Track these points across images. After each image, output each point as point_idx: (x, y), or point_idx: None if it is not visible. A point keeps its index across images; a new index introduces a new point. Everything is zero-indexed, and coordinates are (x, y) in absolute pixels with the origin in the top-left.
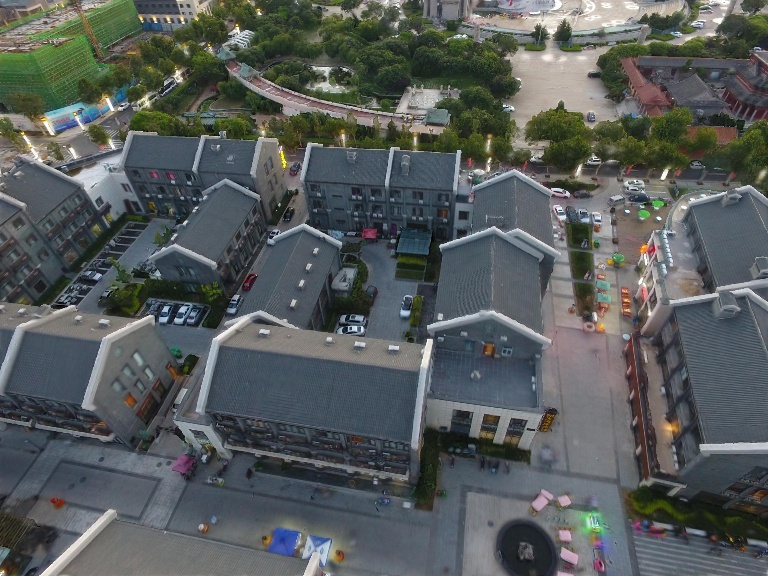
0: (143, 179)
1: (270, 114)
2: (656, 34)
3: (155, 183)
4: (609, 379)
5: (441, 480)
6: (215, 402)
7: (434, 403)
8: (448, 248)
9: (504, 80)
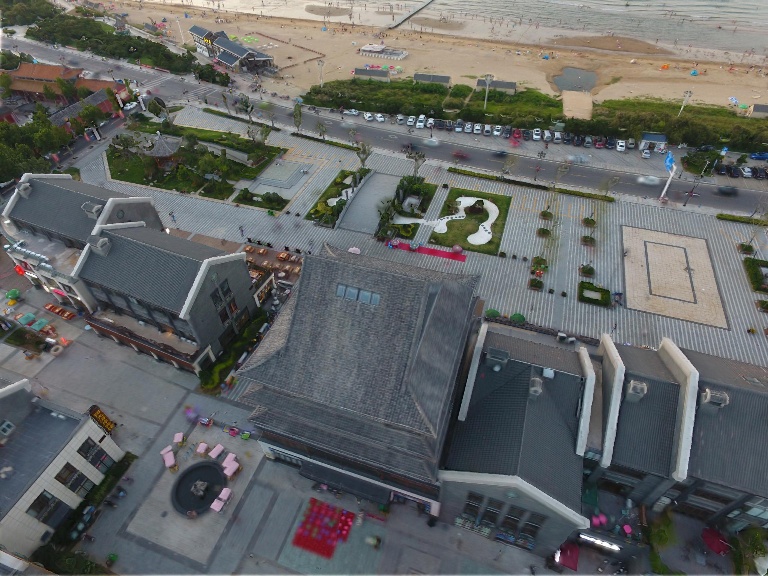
0: None
1: None
2: None
3: None
4: (113, 358)
5: (99, 558)
6: None
7: None
8: None
9: None
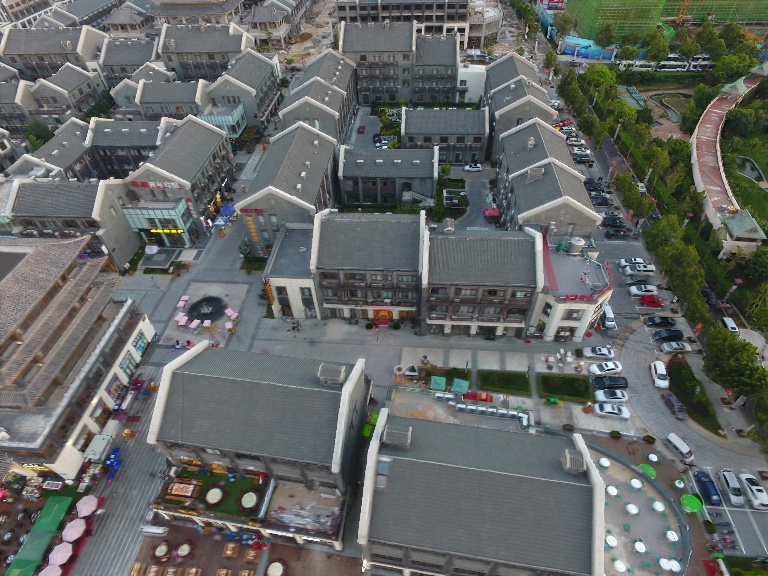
0: None
1: (682, 130)
2: None
3: None
4: None
5: (258, 273)
6: None
7: None
8: None
9: None
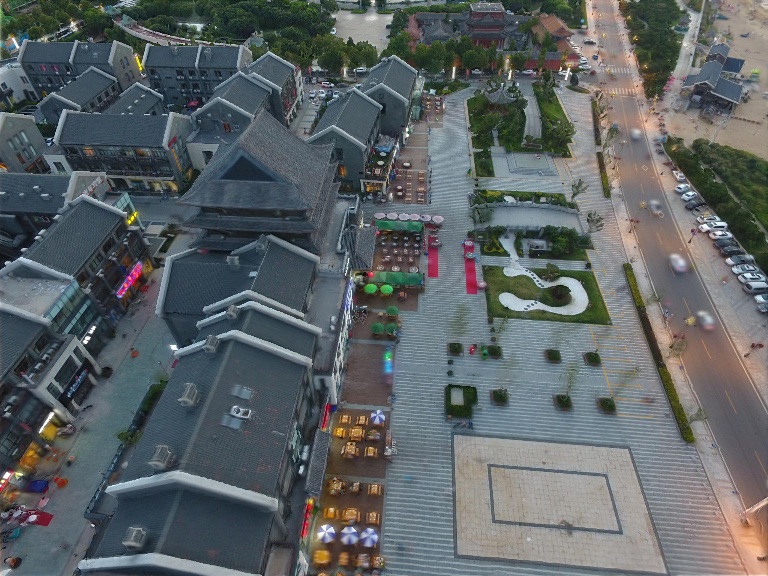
0: (36, 72)
1: None
2: (449, 3)
3: (45, 75)
4: None
5: None
6: (64, 139)
7: (191, 147)
8: (219, 88)
9: (316, 26)
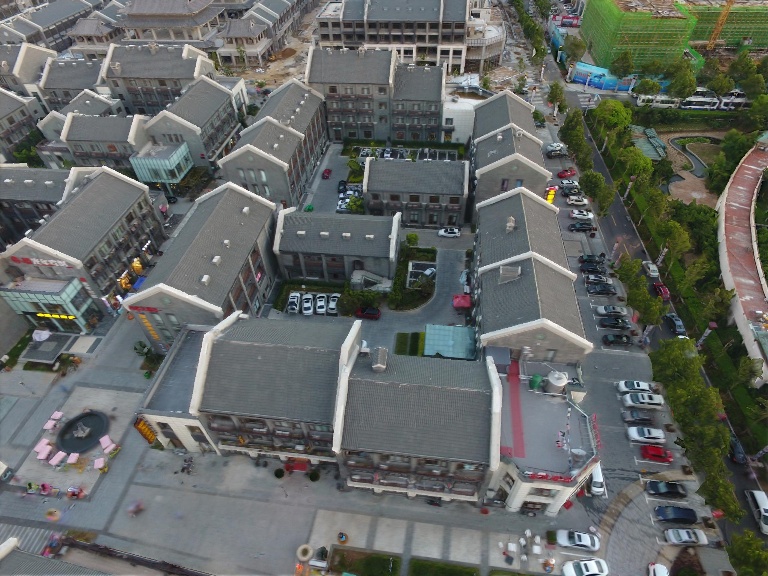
0: None
1: (708, 188)
2: None
3: None
4: (223, 562)
5: None
6: None
7: None
8: None
9: None
